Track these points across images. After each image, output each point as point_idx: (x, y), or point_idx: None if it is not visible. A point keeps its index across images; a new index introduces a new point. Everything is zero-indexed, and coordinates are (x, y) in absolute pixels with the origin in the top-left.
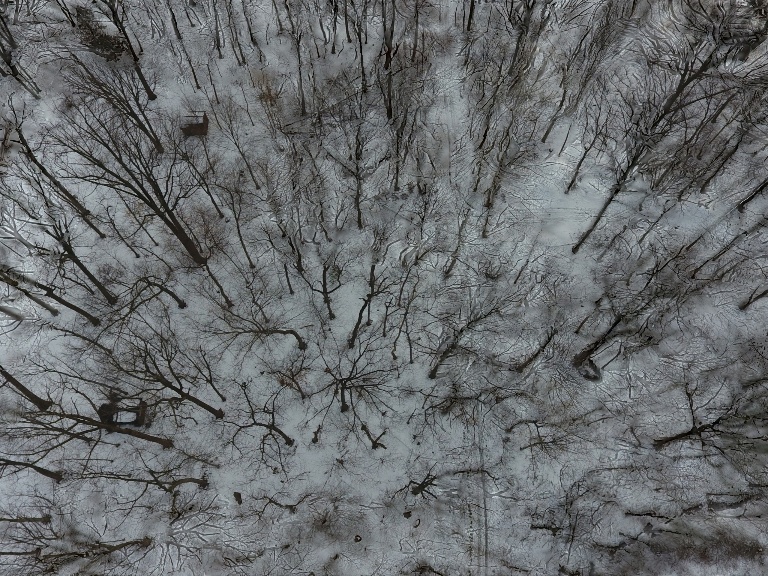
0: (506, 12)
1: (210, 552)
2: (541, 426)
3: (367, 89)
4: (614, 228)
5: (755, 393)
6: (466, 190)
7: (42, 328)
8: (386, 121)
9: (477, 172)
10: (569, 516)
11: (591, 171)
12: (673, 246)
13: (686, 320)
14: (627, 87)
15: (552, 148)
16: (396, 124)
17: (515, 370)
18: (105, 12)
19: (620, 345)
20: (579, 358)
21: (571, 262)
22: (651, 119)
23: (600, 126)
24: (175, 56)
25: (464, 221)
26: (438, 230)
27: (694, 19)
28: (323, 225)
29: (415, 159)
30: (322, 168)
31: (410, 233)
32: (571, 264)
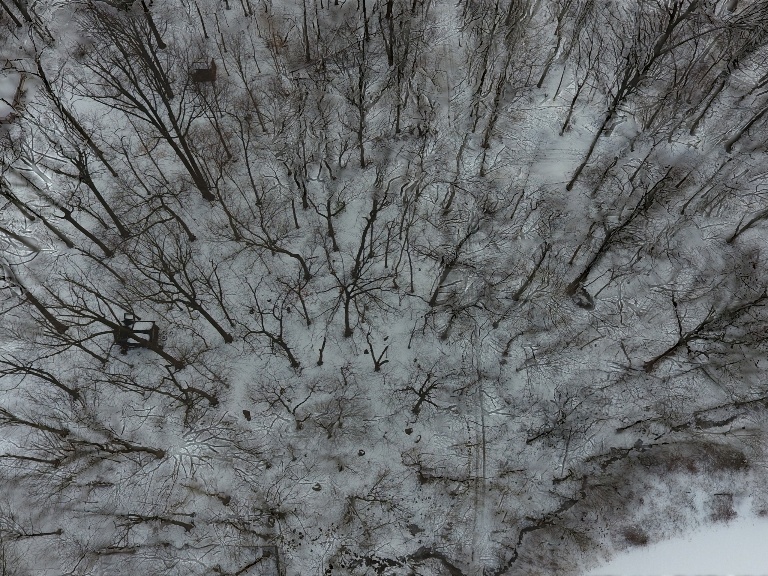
0: None
1: (221, 463)
2: (536, 349)
3: (369, 37)
4: (606, 160)
5: (741, 320)
6: None
7: (58, 259)
8: (387, 68)
9: None
10: (562, 413)
11: (585, 114)
12: None
13: (675, 253)
14: (618, 20)
15: (547, 93)
16: (397, 70)
17: (512, 298)
18: None
19: (612, 274)
20: (573, 285)
21: (565, 199)
22: (642, 61)
23: (592, 60)
24: (184, 7)
25: (462, 146)
26: (438, 169)
27: None
28: (327, 162)
29: (415, 102)
30: (326, 112)
31: (411, 171)
32: (565, 200)
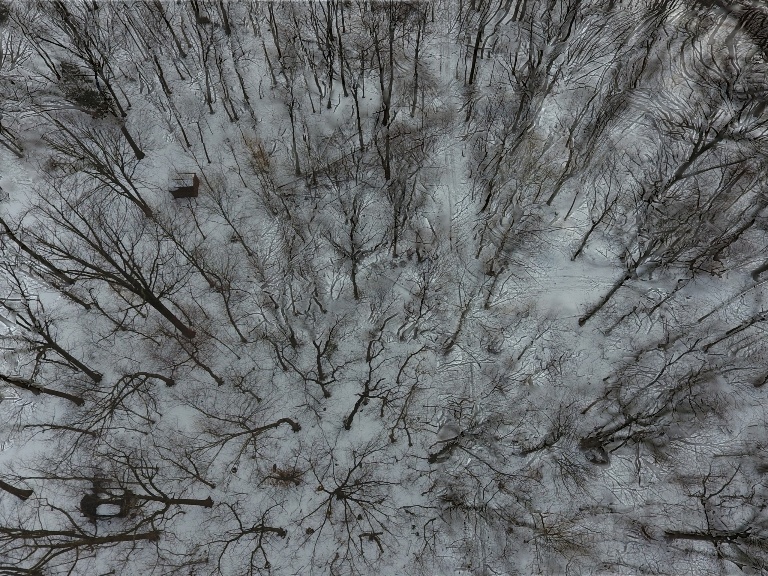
0: (510, 66)
1: None
2: (546, 516)
3: (364, 148)
4: (623, 308)
5: None
6: (467, 257)
7: (23, 409)
8: (384, 182)
9: (479, 238)
10: None
11: None
12: (685, 318)
13: (698, 399)
14: (638, 166)
15: (558, 211)
16: (394, 186)
17: (519, 455)
18: (91, 66)
19: (629, 429)
20: (586, 444)
21: (577, 336)
22: (662, 186)
23: (609, 203)
24: (164, 111)
25: (465, 311)
26: (438, 300)
27: (707, 76)
28: (317, 299)
29: None
30: (317, 233)
31: (409, 304)
32: (577, 338)
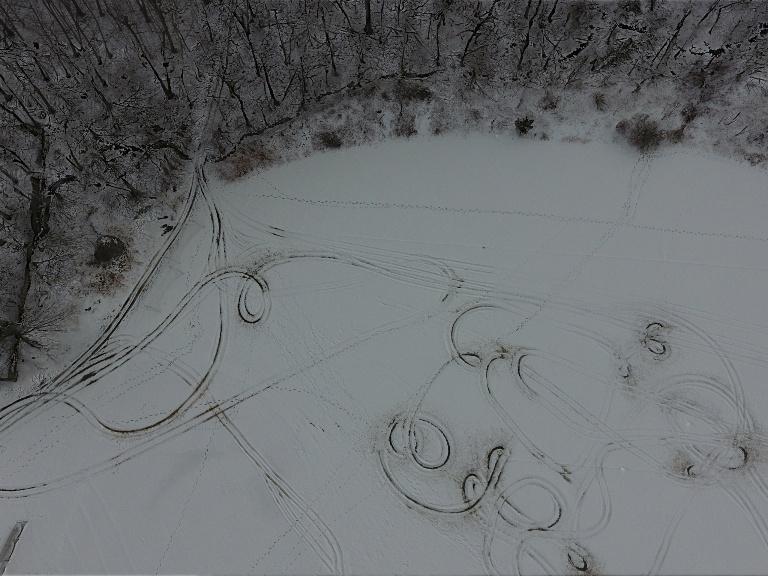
0: None
1: (8, 72)
2: (279, 13)
3: None
4: None
5: (456, 6)
6: None
7: None
8: None
9: None
10: None
11: None
12: None
13: None
14: None
15: None
16: None
17: None
18: None
19: None
20: None
21: None
22: None
23: None
24: None
25: None
26: None
27: None
28: None
29: None
30: None
31: None
32: None
